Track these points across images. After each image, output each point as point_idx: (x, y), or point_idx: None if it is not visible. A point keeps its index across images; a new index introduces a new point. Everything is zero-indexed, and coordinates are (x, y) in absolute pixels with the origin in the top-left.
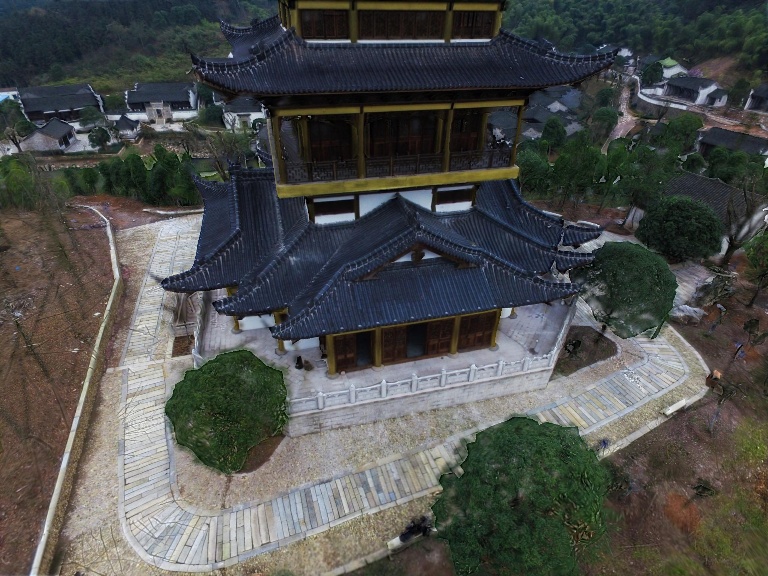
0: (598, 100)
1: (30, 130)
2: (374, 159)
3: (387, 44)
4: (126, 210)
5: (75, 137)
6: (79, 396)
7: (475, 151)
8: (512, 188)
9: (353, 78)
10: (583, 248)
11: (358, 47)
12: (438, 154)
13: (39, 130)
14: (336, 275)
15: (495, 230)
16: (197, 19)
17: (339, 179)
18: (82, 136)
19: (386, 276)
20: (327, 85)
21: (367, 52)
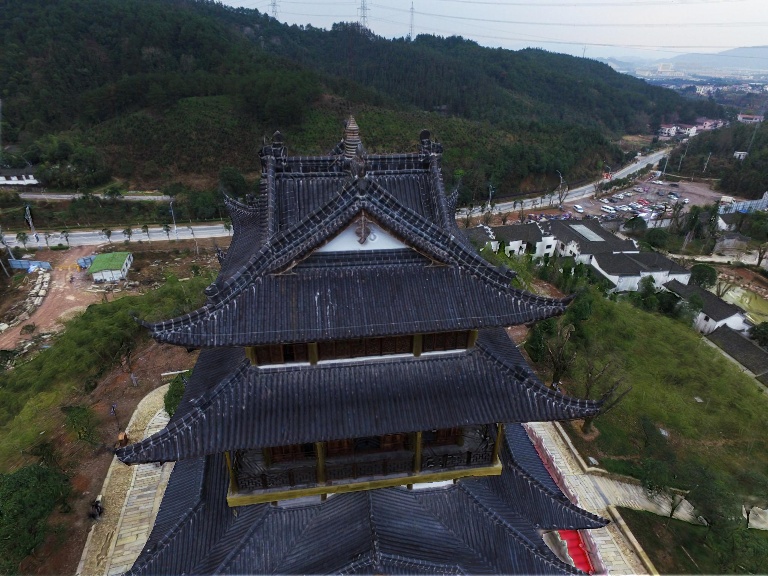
0: None
1: None
2: None
3: None
4: None
5: None
6: None
7: None
8: (324, 575)
9: None
10: None
11: None
12: None
13: None
14: None
15: None
16: None
17: None
18: None
19: None
20: None
21: None
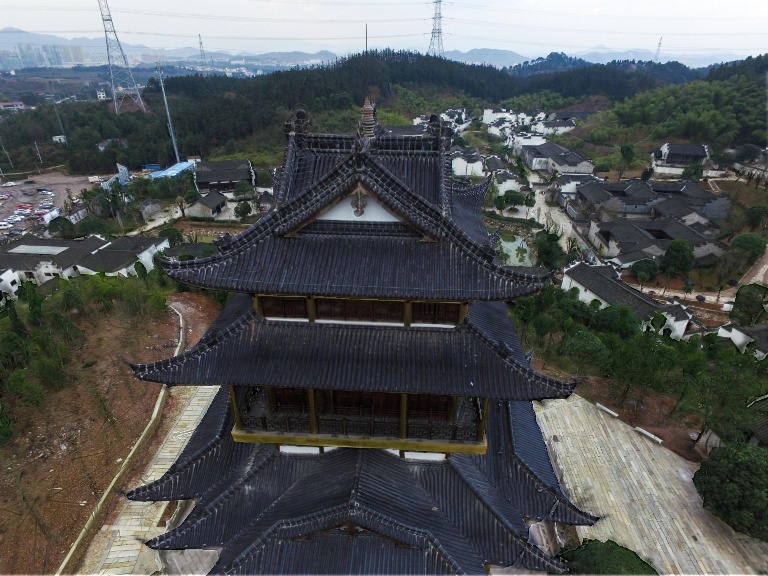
0: (747, 218)
1: (195, 198)
2: (326, 420)
3: (344, 325)
4: (207, 321)
5: (227, 206)
6: (62, 561)
7: (446, 413)
8: (509, 430)
9: (292, 369)
10: (628, 473)
11: (315, 326)
12: (394, 422)
13: (200, 201)
14: (266, 534)
15: (466, 492)
16: (349, 104)
17: (292, 431)
18: (233, 204)
19: (321, 539)
20: (263, 378)
21: (323, 332)
